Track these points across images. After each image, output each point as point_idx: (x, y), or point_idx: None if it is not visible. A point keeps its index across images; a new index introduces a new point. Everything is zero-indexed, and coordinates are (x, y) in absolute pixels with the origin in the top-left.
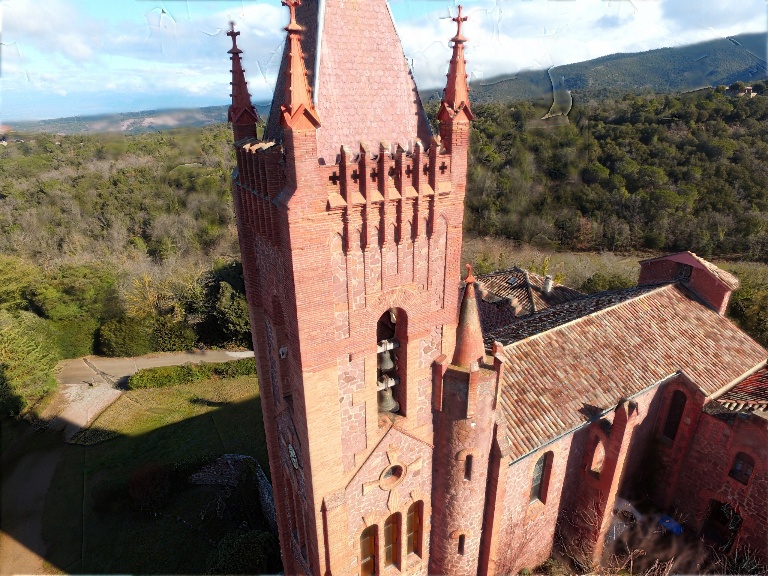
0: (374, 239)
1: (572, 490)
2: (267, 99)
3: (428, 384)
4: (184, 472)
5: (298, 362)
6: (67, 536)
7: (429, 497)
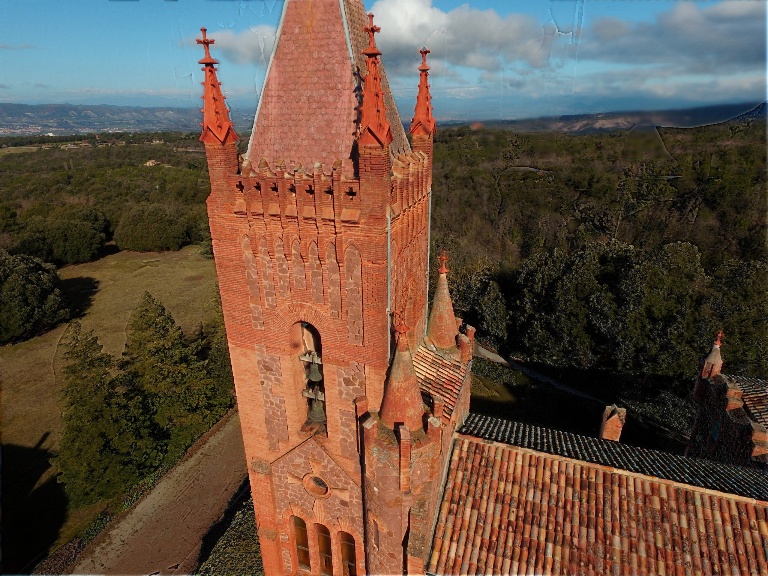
0: (280, 249)
1: None
2: None
3: (352, 419)
4: None
5: None
6: None
7: (362, 540)
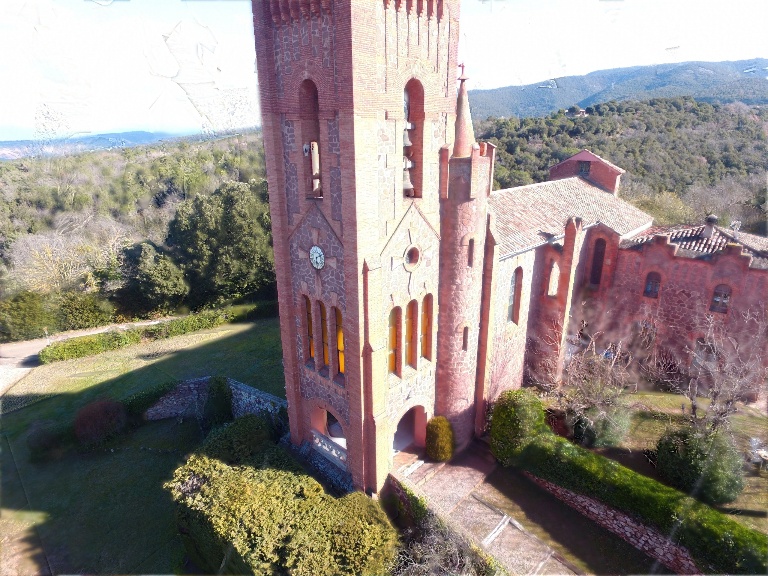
0: (404, 3)
1: (534, 319)
2: (172, 70)
3: (437, 171)
4: (139, 406)
5: (348, 107)
6: (1, 491)
7: (437, 294)
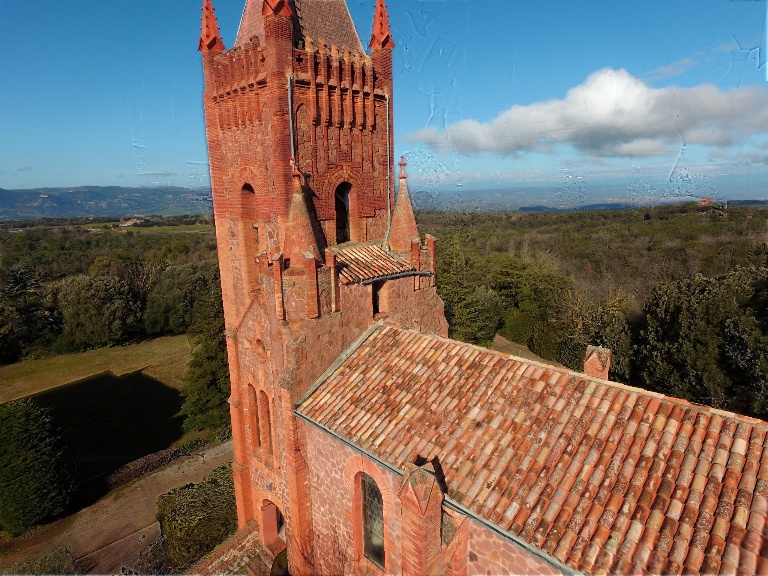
0: None
1: None
2: None
3: None
4: None
5: None
6: None
7: None
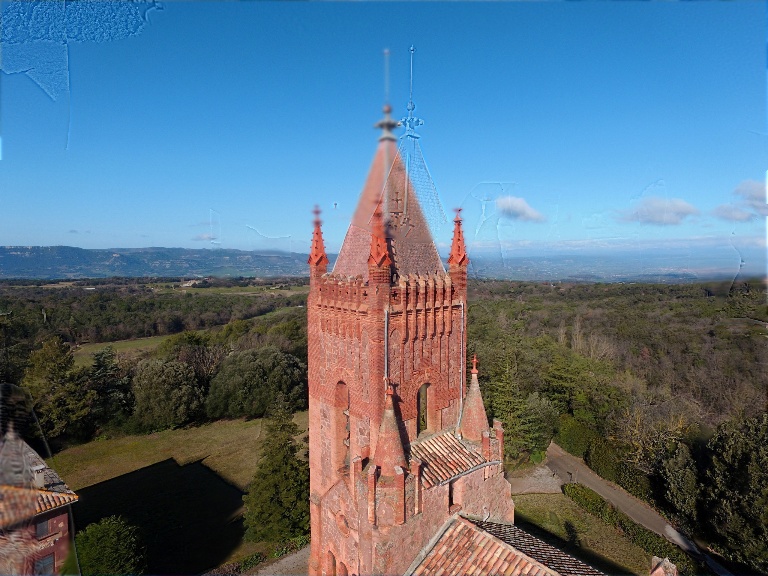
0: None
1: None
2: None
3: None
4: None
5: None
6: None
7: None
